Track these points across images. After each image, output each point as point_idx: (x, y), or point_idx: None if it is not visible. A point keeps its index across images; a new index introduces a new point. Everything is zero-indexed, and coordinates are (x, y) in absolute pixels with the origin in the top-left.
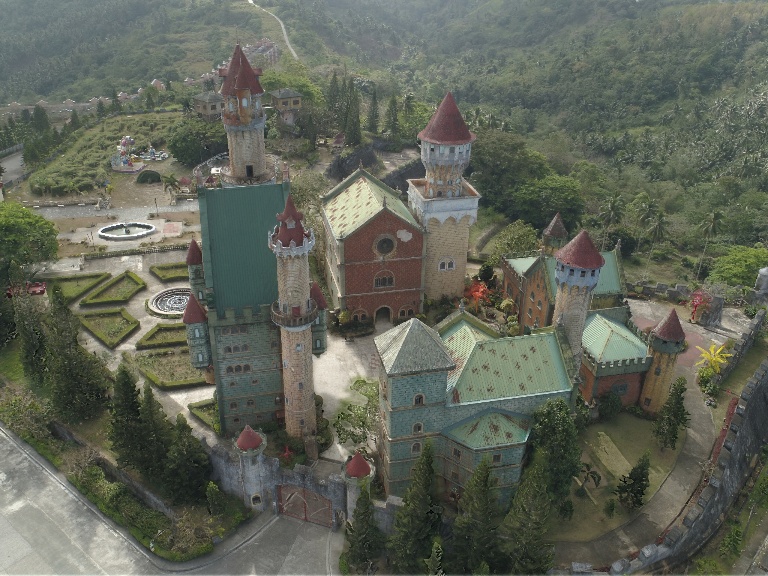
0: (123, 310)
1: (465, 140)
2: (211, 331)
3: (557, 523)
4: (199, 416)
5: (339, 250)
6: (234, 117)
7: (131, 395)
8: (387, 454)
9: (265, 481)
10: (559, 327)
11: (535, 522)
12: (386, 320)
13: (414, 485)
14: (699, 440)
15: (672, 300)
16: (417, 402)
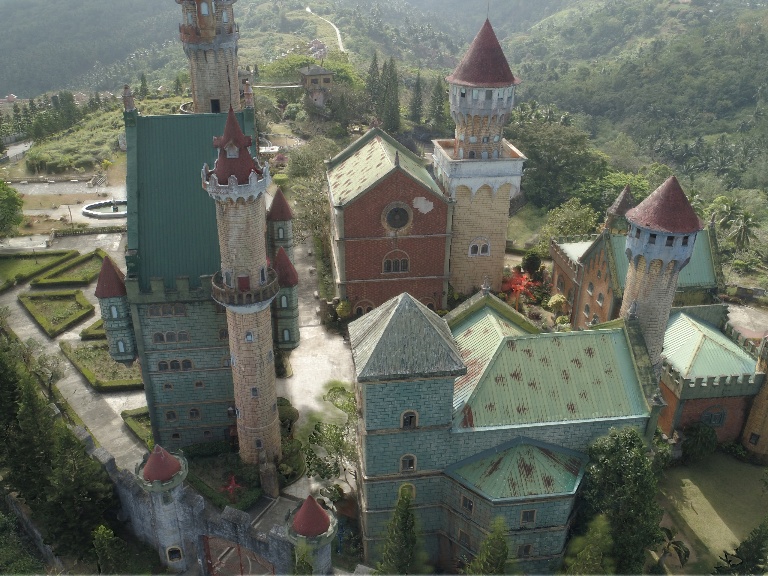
0: (78, 292)
1: (506, 82)
2: (133, 310)
3: None
4: (132, 428)
5: (337, 221)
6: (192, 31)
7: (10, 393)
8: (364, 498)
9: (185, 528)
10: (630, 320)
11: None
12: None
13: (384, 560)
14: None
15: None
16: (406, 423)
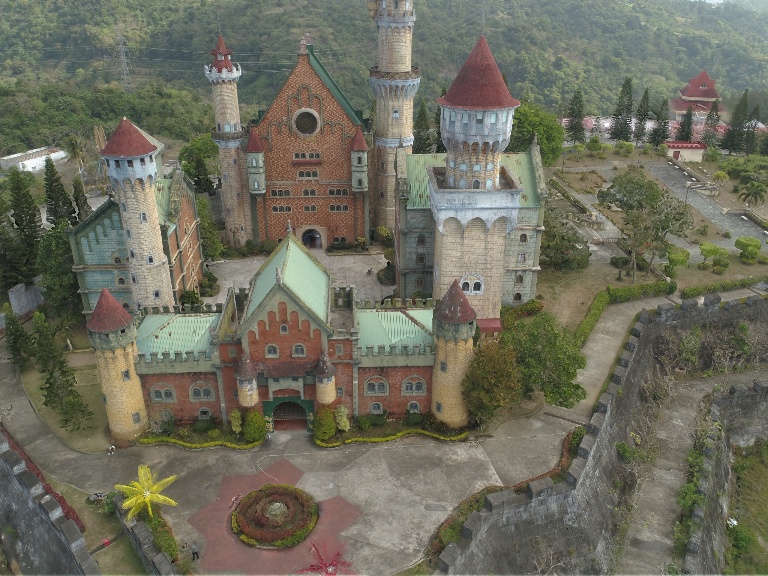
0: None
1: (449, 103)
2: None
3: None
4: None
5: None
6: None
7: None
8: None
9: None
10: None
11: None
12: None
13: None
14: (54, 455)
15: None
16: None
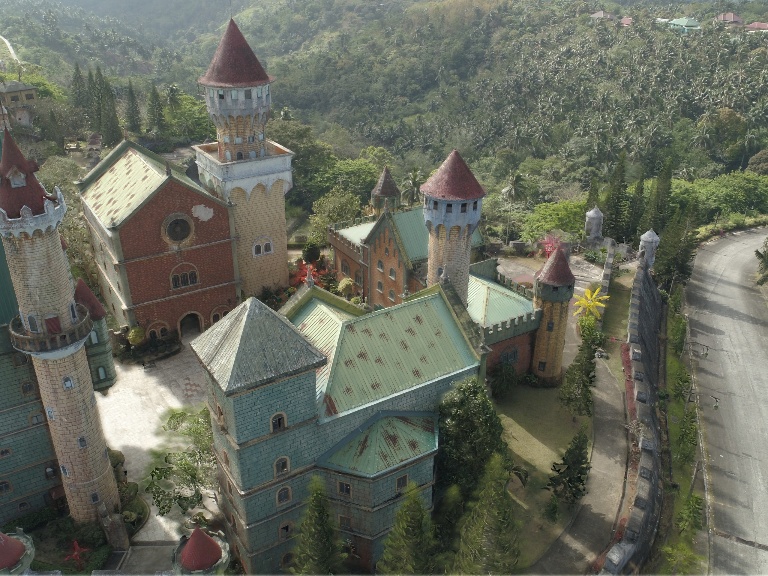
0: None
1: (262, 81)
2: None
3: None
4: None
5: (113, 244)
6: None
7: None
8: (240, 516)
9: None
10: (445, 284)
11: None
12: (195, 331)
13: None
14: (607, 399)
15: (519, 254)
16: (275, 426)
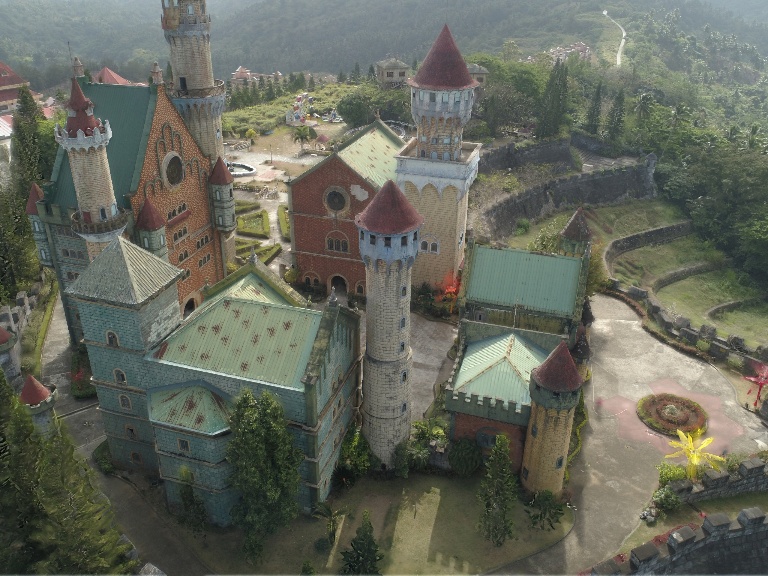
0: None
1: (451, 87)
2: (47, 227)
3: None
4: None
5: None
6: (164, 20)
7: None
8: None
9: None
10: (331, 306)
11: (232, 551)
12: (344, 293)
13: None
14: (571, 555)
15: (749, 373)
16: (112, 341)
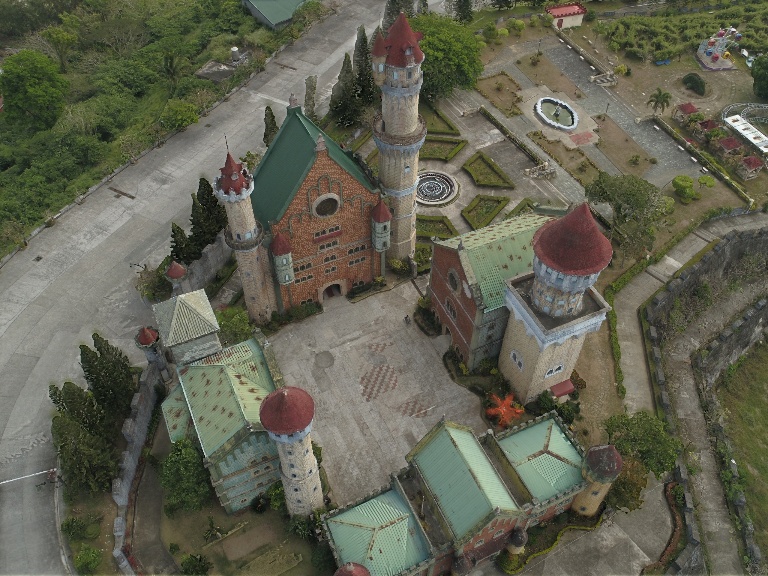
0: None
1: (557, 265)
2: None
3: (180, 513)
4: None
5: None
6: None
7: None
8: None
9: None
10: None
11: None
12: None
13: None
14: None
15: None
16: None
